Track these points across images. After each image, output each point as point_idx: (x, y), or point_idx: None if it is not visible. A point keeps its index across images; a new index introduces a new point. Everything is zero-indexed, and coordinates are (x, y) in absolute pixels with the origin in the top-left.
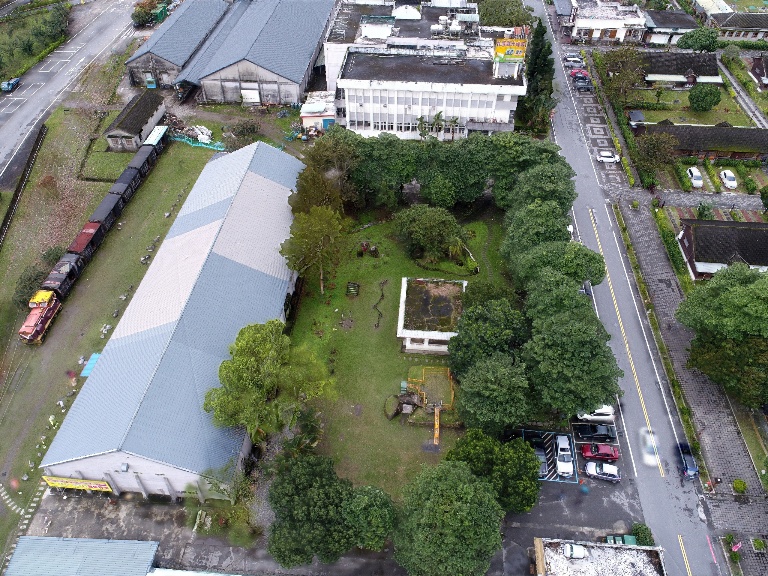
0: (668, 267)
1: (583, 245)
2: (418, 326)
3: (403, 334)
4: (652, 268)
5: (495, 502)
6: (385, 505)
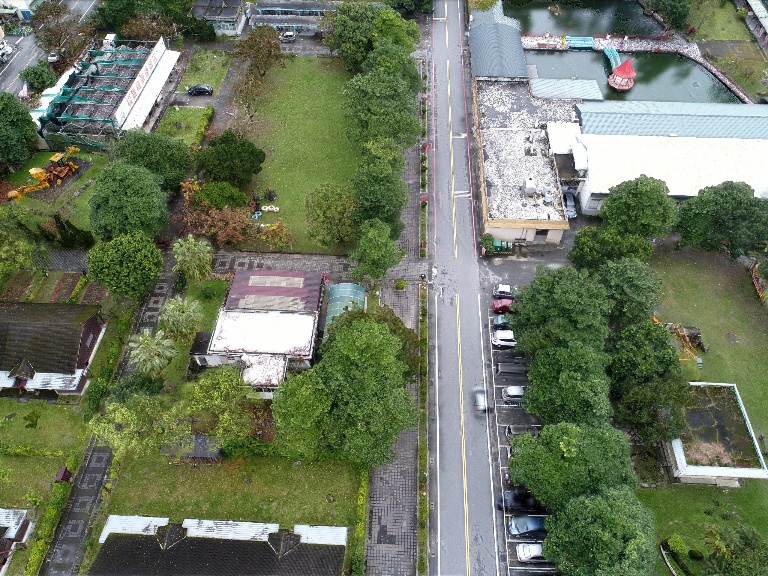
0: (372, 572)
1: (547, 477)
2: (718, 395)
3: (731, 384)
4: (397, 569)
5: (614, 207)
6: (686, 213)
